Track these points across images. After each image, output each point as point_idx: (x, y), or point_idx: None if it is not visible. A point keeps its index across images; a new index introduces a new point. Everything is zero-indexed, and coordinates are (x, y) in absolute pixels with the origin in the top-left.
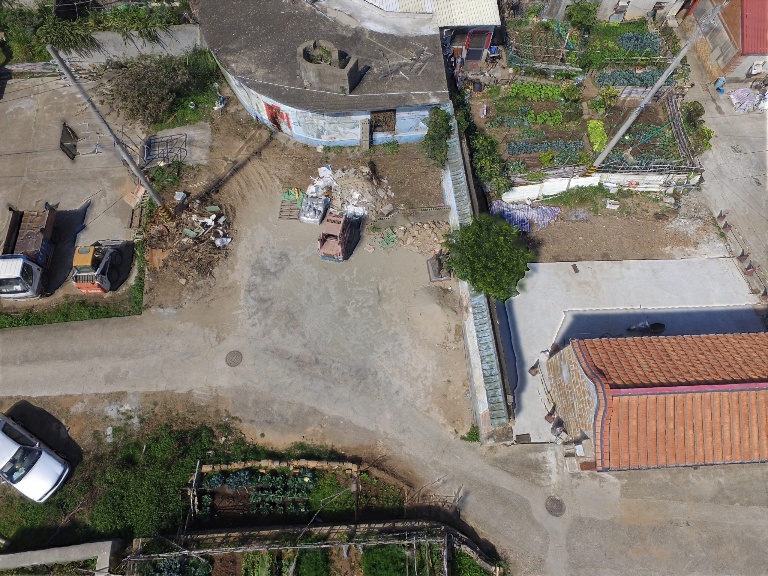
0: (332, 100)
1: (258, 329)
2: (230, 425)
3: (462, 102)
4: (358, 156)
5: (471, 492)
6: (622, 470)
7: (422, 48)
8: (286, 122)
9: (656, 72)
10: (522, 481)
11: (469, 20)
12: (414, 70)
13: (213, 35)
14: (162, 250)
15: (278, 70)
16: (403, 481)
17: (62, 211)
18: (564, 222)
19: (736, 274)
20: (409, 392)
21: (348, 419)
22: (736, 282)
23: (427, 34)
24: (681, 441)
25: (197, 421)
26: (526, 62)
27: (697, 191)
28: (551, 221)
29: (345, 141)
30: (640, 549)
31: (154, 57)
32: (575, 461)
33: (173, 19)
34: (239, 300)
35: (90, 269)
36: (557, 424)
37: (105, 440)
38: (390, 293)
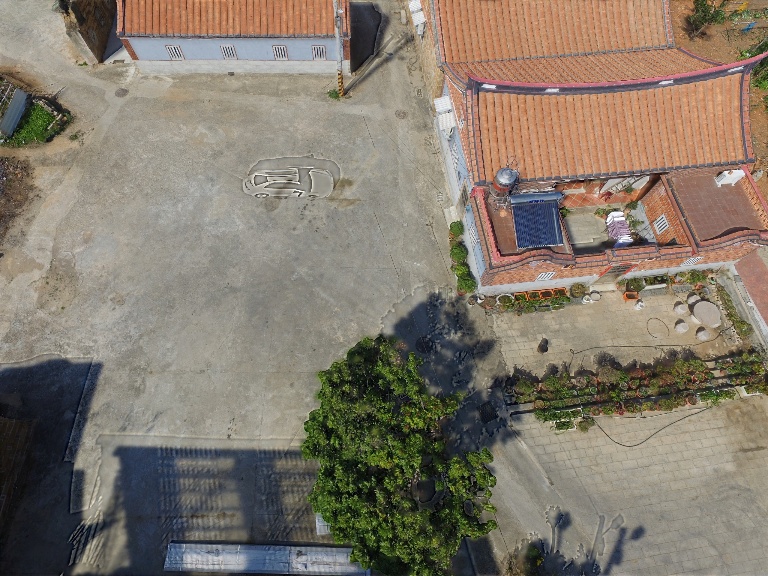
0: None
1: None
2: None
3: None
4: None
5: (70, 89)
6: (134, 36)
7: None
8: None
9: None
10: (106, 82)
11: None
12: None
13: None
14: None
15: None
16: (24, 83)
17: None
18: None
19: None
20: (51, 41)
21: (0, 53)
22: None
23: None
24: (176, 18)
25: None
26: None
27: None
28: None
29: None
30: (168, 112)
31: None
32: None
33: None
34: None
35: None
36: None
37: None
38: None
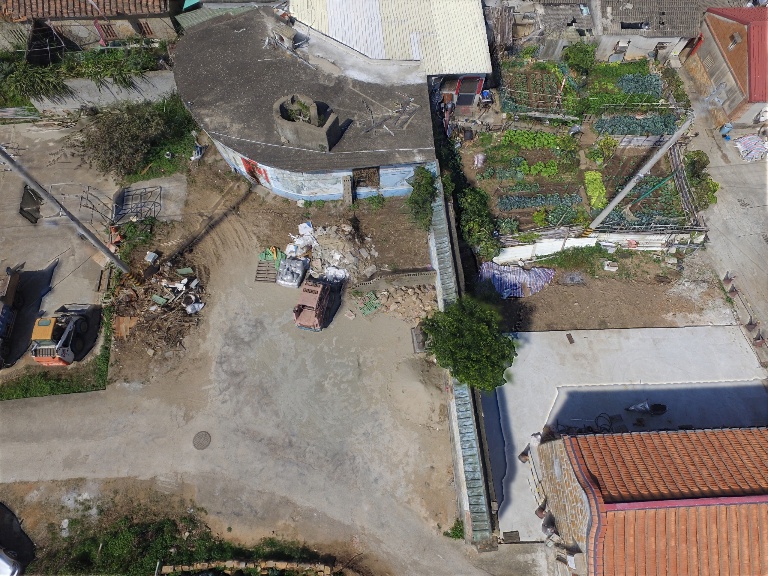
0: (311, 158)
1: (229, 407)
2: (195, 518)
3: (452, 152)
4: (341, 211)
5: None
6: None
7: (408, 99)
8: (264, 177)
9: (658, 118)
10: None
11: (459, 68)
12: (399, 124)
13: (188, 86)
14: (130, 317)
15: (255, 125)
16: None
17: (28, 272)
18: (559, 286)
19: (744, 344)
20: (389, 480)
21: (322, 511)
22: (744, 354)
23: (414, 83)
24: (683, 559)
25: (160, 513)
26: (520, 107)
27: (701, 250)
28: (545, 285)
29: (327, 196)
30: None
31: (131, 102)
32: (567, 569)
33: (151, 63)
34: (210, 373)
35: (51, 342)
36: (548, 520)
37: (60, 535)
38: (371, 366)
